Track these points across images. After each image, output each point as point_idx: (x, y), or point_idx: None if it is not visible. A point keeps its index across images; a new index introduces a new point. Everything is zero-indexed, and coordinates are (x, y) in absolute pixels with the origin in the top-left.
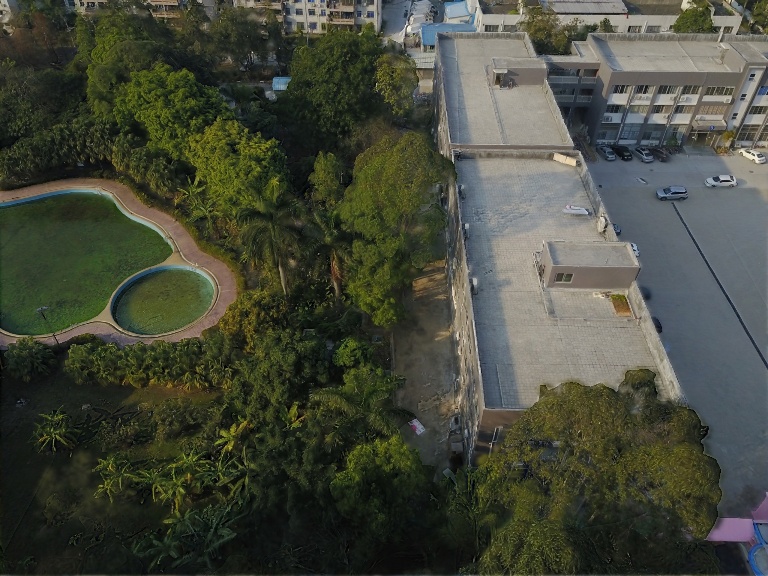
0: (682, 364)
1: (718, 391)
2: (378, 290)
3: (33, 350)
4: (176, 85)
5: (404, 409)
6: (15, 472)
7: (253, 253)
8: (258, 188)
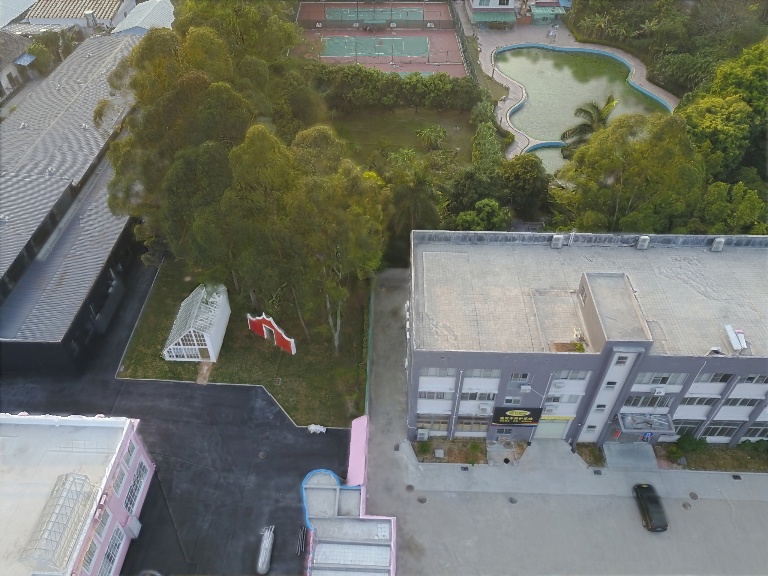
0: (598, 542)
1: (561, 573)
2: (577, 231)
3: (483, 110)
4: (767, 62)
5: (419, 208)
6: (411, 137)
7: (566, 139)
8: (609, 102)
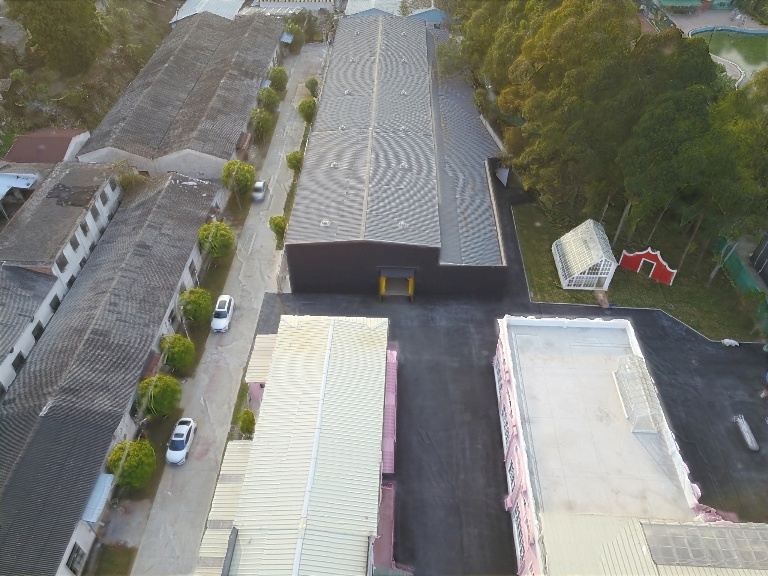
0: None
1: None
2: None
3: (729, 83)
4: None
5: None
6: None
7: None
8: None
